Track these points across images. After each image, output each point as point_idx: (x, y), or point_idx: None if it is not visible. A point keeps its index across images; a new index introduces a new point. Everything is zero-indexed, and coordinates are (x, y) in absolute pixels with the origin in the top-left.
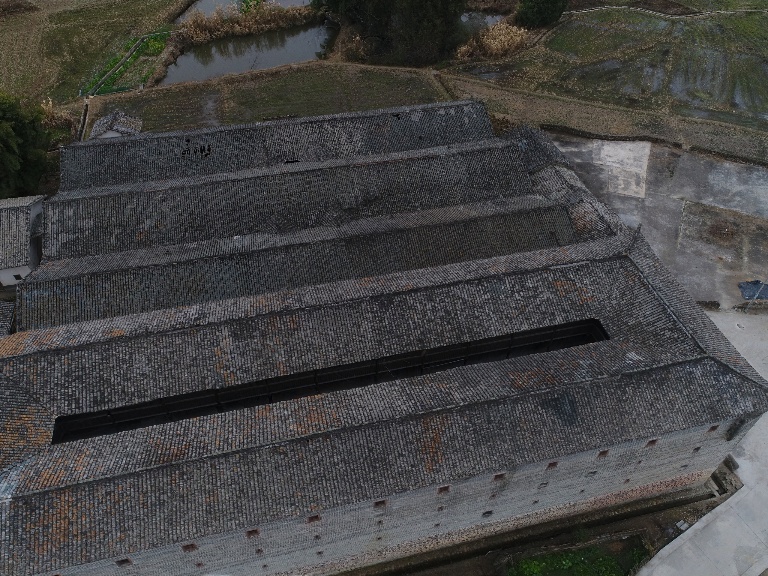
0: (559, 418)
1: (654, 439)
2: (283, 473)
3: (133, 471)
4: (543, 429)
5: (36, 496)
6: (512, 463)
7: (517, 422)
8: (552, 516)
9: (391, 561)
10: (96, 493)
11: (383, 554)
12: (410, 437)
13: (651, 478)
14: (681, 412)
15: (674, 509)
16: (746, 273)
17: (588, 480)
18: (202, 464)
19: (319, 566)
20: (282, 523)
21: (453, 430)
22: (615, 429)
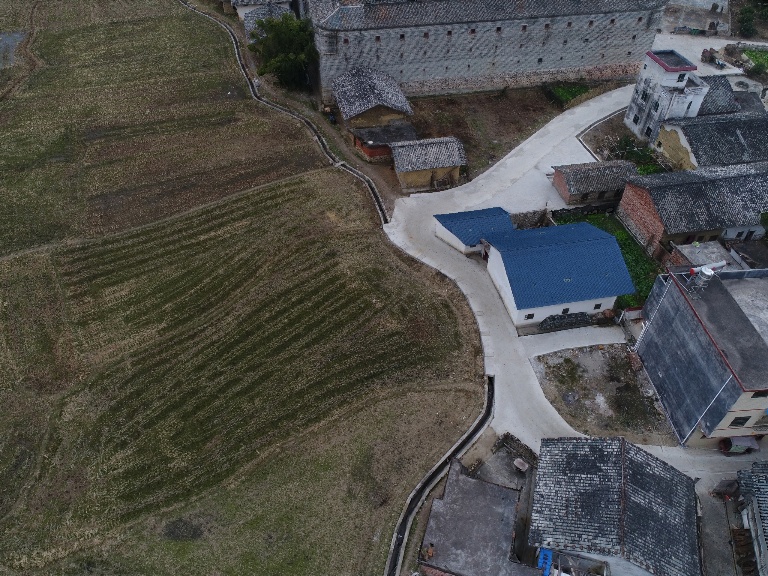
0: (573, 2)
1: (613, 19)
2: (463, 8)
3: (407, 1)
4: (566, 5)
5: (372, 6)
6: (553, 13)
7: (555, 1)
8: (568, 79)
9: (495, 91)
10: (394, 7)
11: (493, 82)
12: (512, 2)
13: (614, 58)
14: (625, 4)
15: (626, 83)
16: (680, 25)
17: (585, 47)
18: (432, 3)
19: (466, 80)
20: (461, 30)
21: (529, 2)
22: (596, 7)
